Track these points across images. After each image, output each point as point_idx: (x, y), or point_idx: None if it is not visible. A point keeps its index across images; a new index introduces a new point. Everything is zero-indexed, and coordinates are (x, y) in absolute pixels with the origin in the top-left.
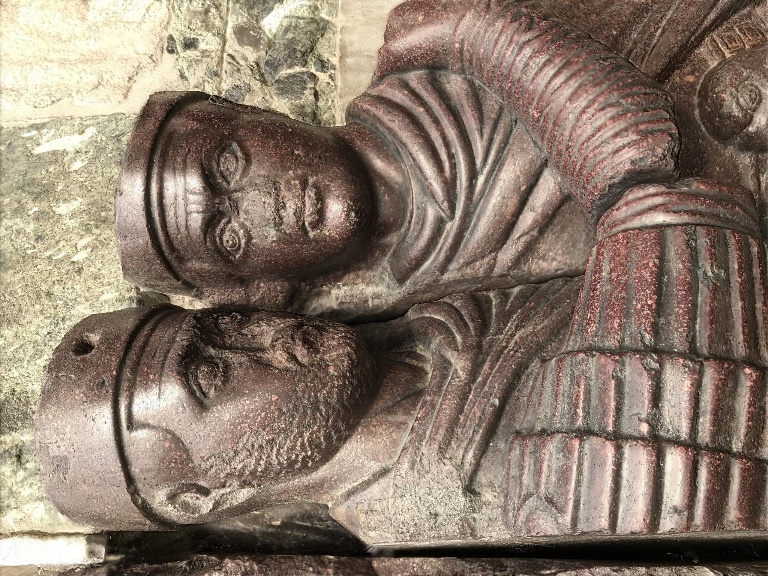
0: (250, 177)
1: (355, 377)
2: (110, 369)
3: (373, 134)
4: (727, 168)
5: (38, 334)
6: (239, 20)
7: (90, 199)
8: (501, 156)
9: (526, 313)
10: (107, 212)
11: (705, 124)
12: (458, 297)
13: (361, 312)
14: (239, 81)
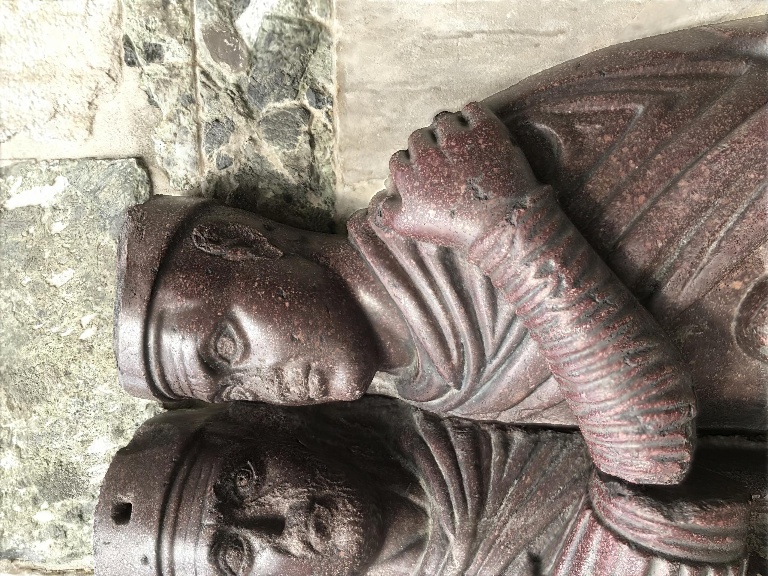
0: (250, 359)
1: (363, 552)
2: (149, 549)
3: (377, 283)
4: (750, 375)
5: (68, 412)
6: (208, 18)
7: (82, 271)
8: (512, 353)
9: (521, 493)
10: (103, 288)
11: (738, 339)
12: (460, 442)
13: (369, 393)
14: (219, 114)
